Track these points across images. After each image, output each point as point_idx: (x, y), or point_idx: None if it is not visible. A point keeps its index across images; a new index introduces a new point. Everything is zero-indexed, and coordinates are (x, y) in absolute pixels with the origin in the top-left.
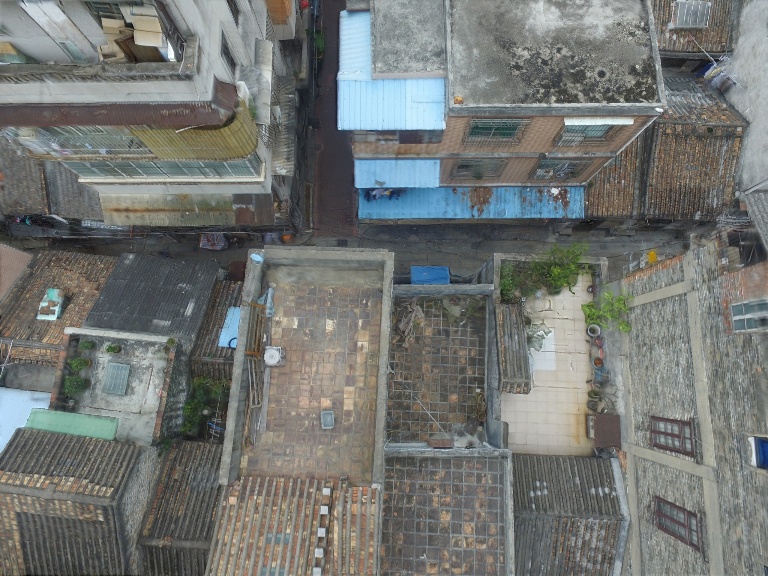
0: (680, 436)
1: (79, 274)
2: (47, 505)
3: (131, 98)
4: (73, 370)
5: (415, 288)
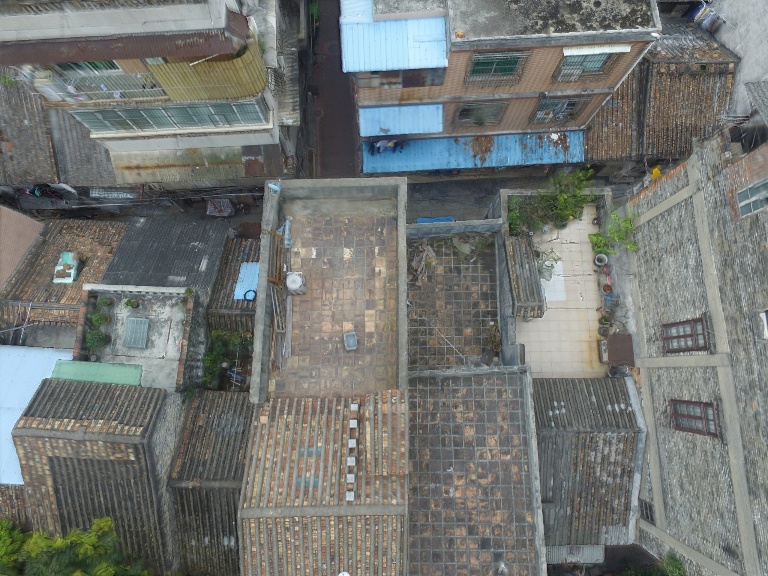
0: (693, 334)
1: (91, 239)
2: (79, 447)
3: (147, 28)
4: (93, 326)
5: (425, 226)
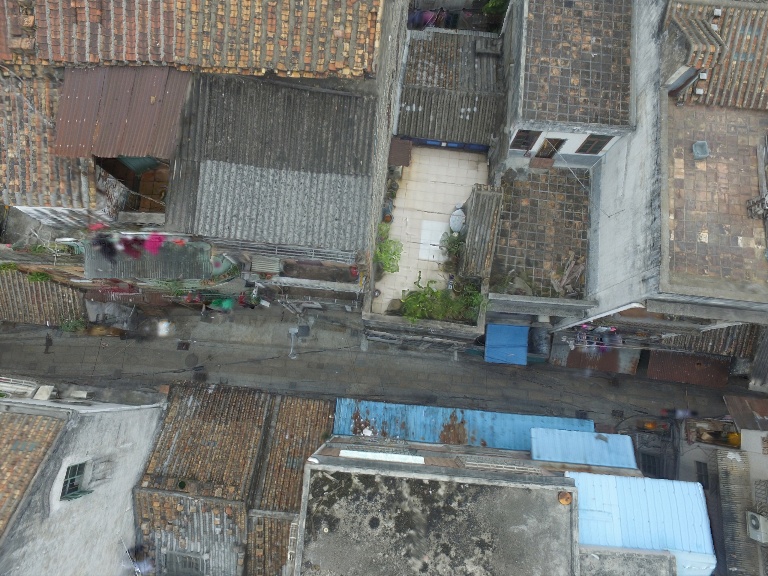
0: None
1: None
2: None
3: None
4: None
5: (573, 301)
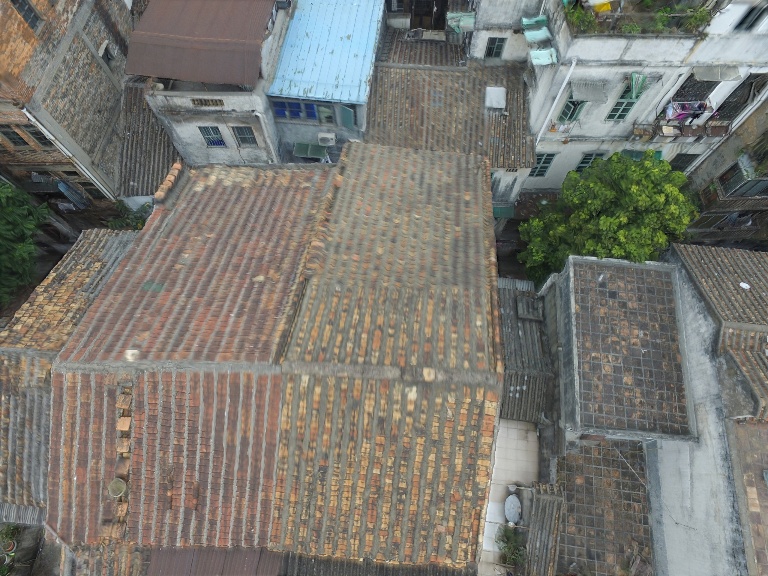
0: None
1: None
2: None
3: None
4: None
5: None
